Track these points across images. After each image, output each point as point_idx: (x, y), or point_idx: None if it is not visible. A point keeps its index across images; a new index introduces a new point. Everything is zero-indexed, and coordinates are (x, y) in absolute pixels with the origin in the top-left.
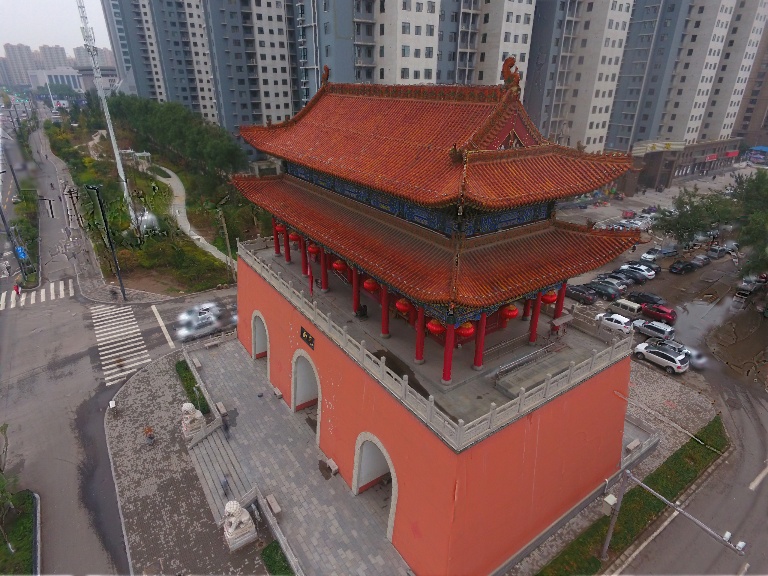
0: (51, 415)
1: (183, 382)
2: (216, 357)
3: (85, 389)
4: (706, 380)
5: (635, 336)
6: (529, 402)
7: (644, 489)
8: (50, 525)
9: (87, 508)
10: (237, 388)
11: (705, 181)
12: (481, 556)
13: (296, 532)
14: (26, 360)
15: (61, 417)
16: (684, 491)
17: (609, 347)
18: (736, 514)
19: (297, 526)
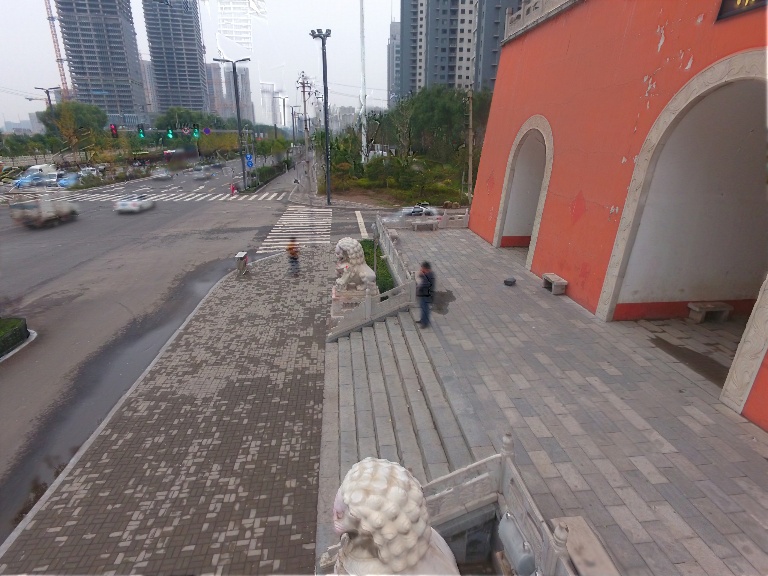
0: (166, 263)
1: None
2: (427, 237)
3: (228, 251)
4: None
5: None
6: None
7: None
8: None
9: (74, 381)
10: (458, 268)
11: None
12: None
13: None
14: (192, 224)
15: (175, 267)
16: None
17: None
18: None
19: None
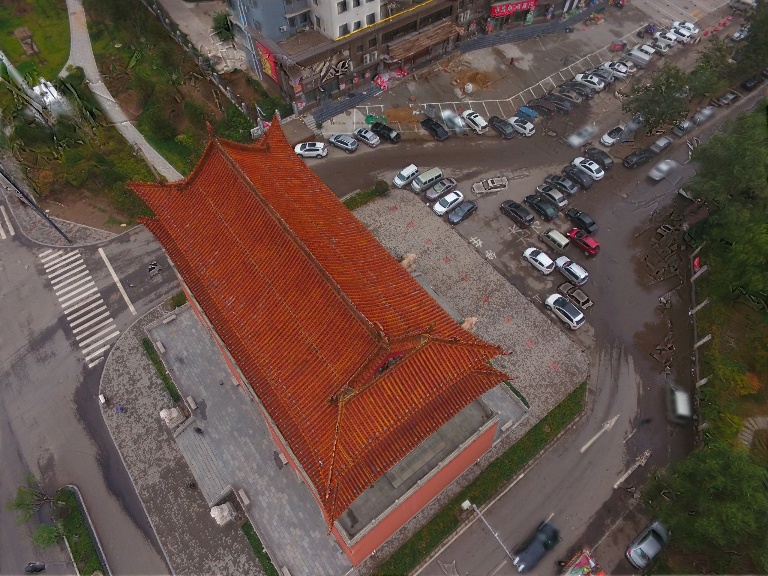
0: (55, 405)
1: (154, 364)
2: (176, 335)
3: (73, 373)
4: (594, 335)
5: (554, 276)
6: (404, 496)
7: (505, 460)
8: (94, 511)
9: (115, 495)
10: (201, 375)
11: (694, 52)
12: (378, 541)
13: (262, 516)
14: (7, 338)
15: (64, 407)
16: (534, 457)
17: (476, 432)
18: (562, 475)
19: (262, 511)
